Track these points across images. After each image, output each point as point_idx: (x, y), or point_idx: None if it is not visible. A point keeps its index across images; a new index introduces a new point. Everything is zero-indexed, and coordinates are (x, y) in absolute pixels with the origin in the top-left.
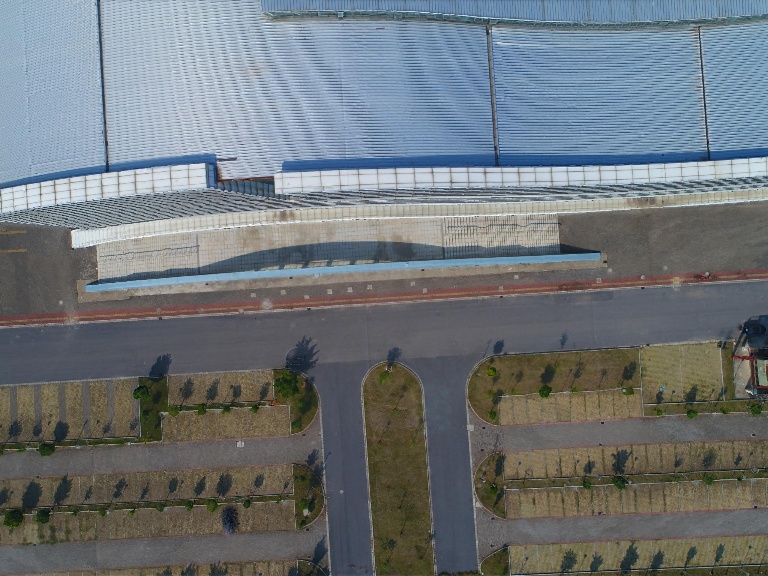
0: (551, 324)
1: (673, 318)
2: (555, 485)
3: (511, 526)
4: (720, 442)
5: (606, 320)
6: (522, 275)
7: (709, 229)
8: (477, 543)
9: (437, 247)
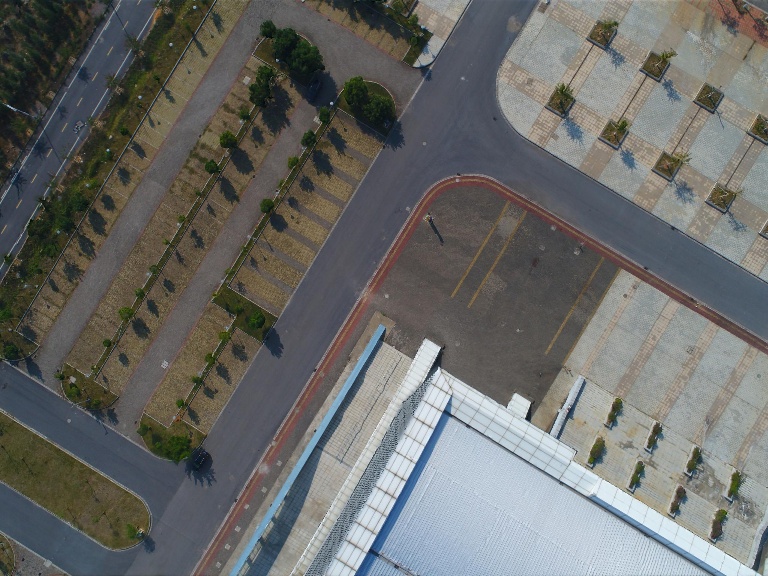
0: None
1: None
2: None
3: None
4: None
5: None
6: None
7: None
8: None
9: None
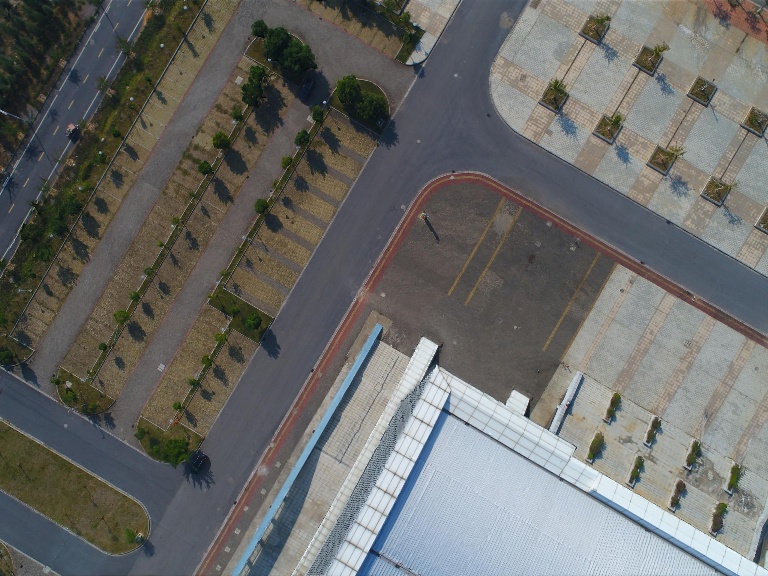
0: None
1: None
2: None
3: None
4: None
5: None
6: None
7: None
8: None
9: None
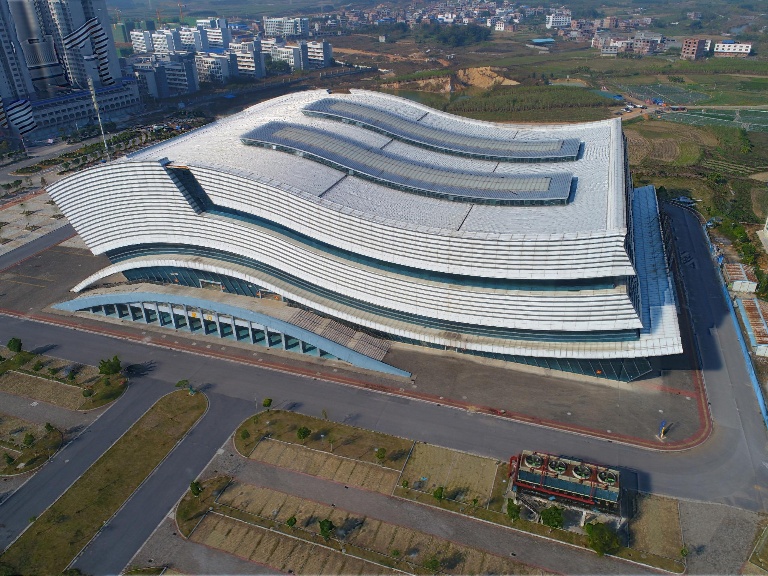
0: (344, 404)
1: (458, 431)
2: (262, 524)
3: (186, 548)
4: (469, 548)
5: (394, 415)
6: (340, 370)
7: (513, 384)
8: (138, 552)
9: None
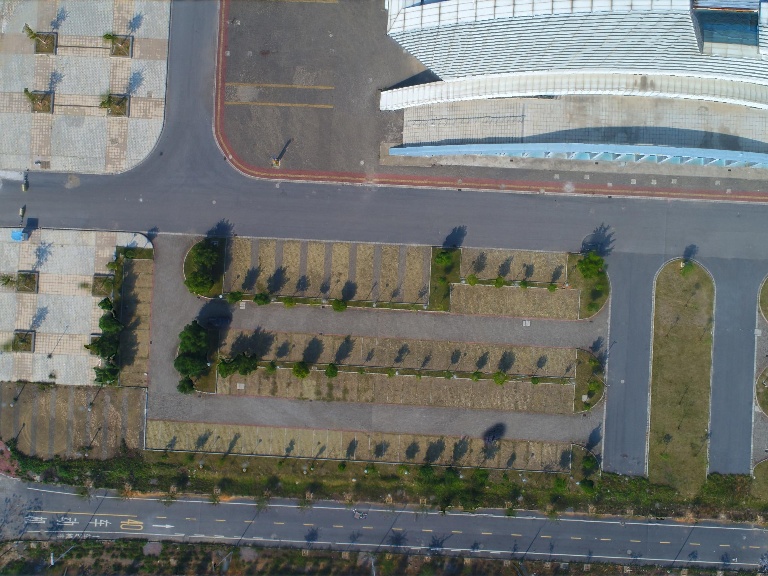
0: None
1: None
2: None
3: None
4: None
5: None
6: None
7: None
8: (752, 447)
9: (764, 143)
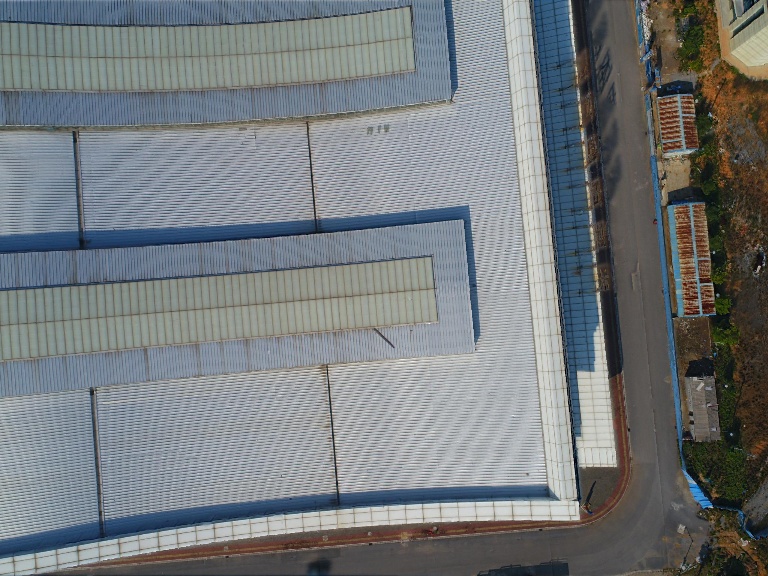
0: None
1: (402, 575)
2: None
3: None
4: None
5: None
6: None
7: None
8: None
9: None
